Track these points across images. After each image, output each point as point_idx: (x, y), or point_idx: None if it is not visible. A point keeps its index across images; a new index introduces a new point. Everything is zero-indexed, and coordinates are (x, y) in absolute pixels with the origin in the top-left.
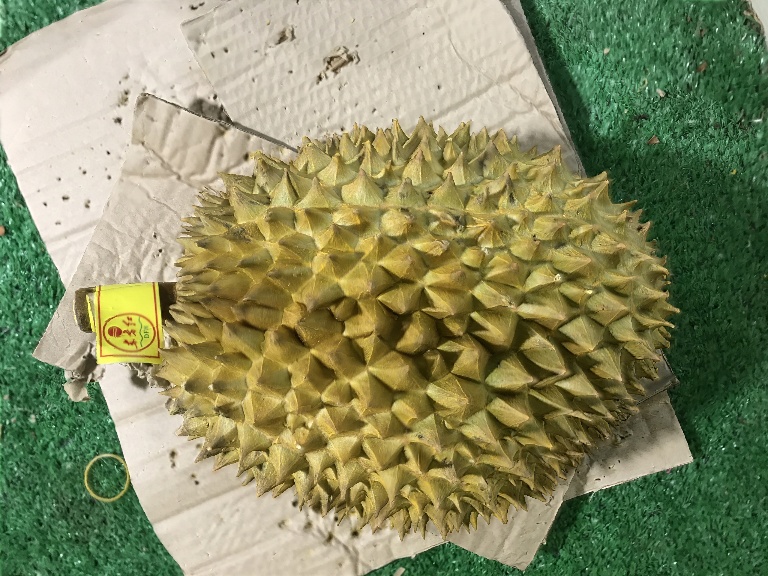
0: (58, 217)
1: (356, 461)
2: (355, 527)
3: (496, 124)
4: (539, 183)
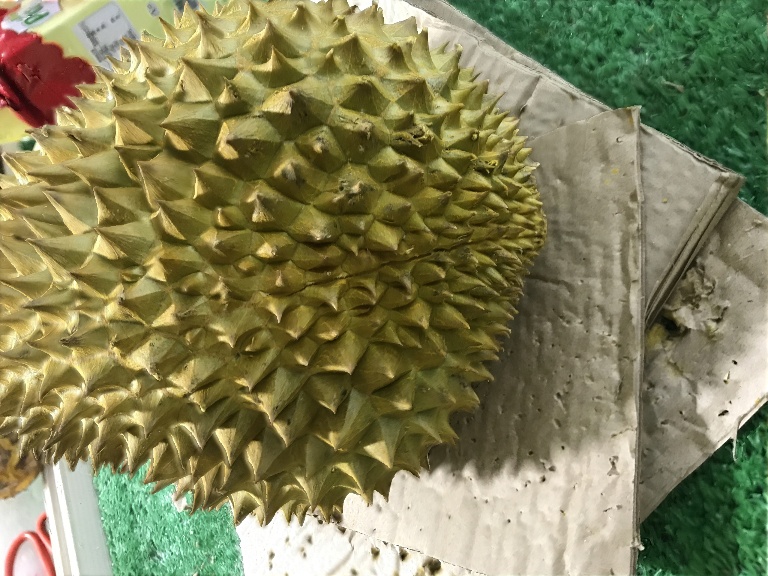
0: None
1: (29, 371)
2: None
3: None
4: None
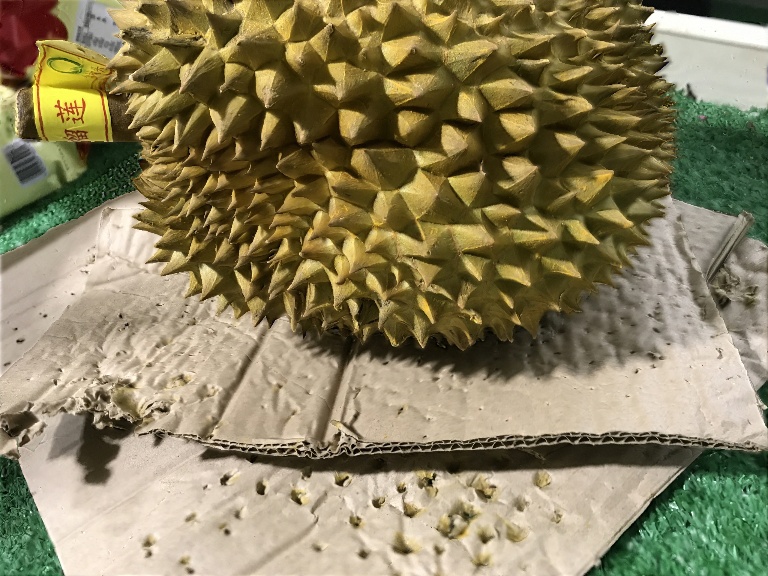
0: (8, 359)
1: None
2: (477, 556)
3: None
4: None
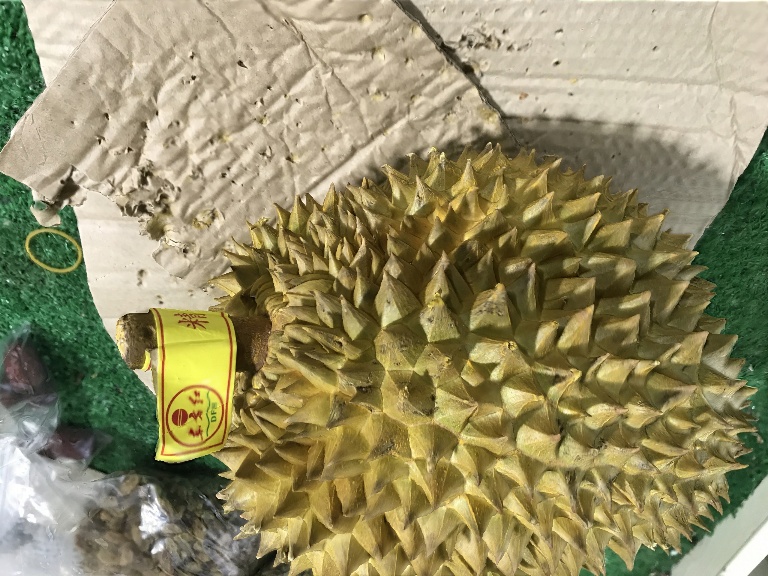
0: None
1: None
2: None
3: (680, 127)
4: (702, 434)
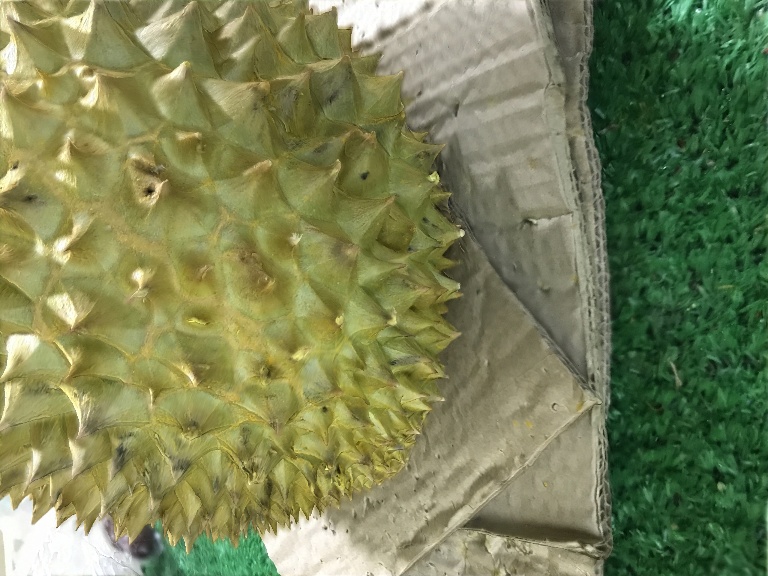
0: None
1: None
2: None
3: None
4: (3, 54)
